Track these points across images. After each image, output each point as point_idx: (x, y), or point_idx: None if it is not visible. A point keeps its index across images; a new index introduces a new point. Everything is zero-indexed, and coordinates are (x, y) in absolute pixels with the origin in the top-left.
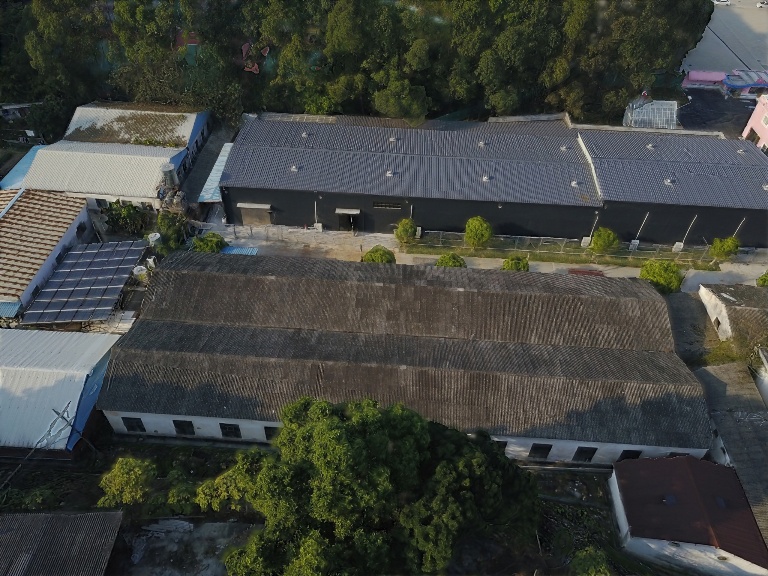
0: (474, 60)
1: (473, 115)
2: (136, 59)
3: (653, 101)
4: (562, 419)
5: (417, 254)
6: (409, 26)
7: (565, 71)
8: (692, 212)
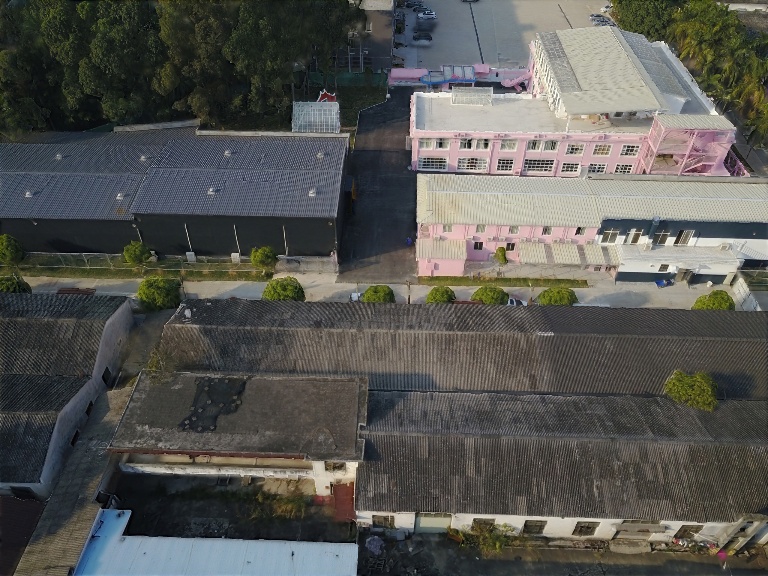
0: (75, 69)
1: None
2: None
3: (313, 102)
4: None
5: None
6: None
7: (169, 77)
8: (227, 222)
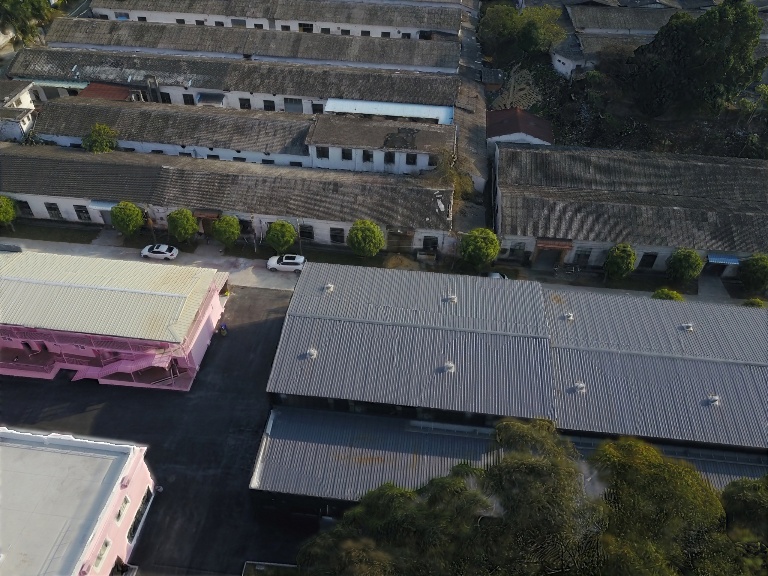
0: None
1: None
2: None
3: None
4: None
5: None
6: None
7: None
8: None
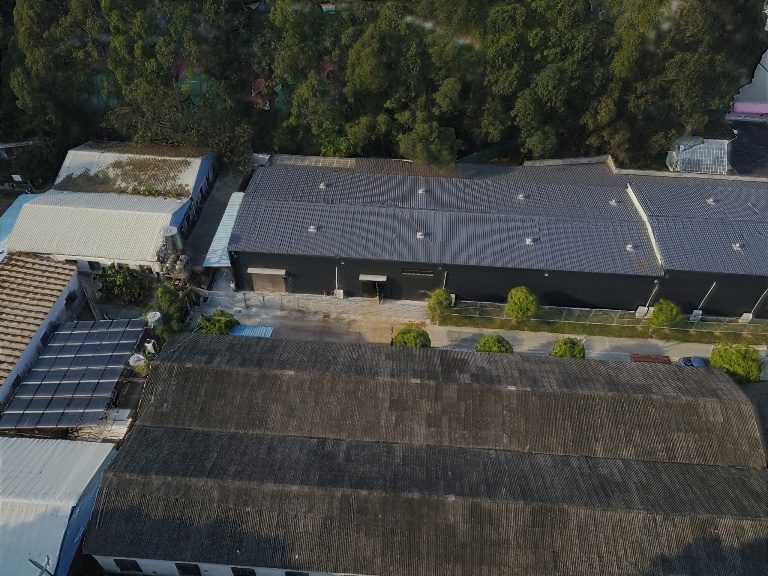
0: (510, 100)
1: (503, 153)
2: (134, 98)
3: None
4: (645, 567)
5: (451, 327)
6: (439, 64)
7: (611, 112)
8: (765, 282)
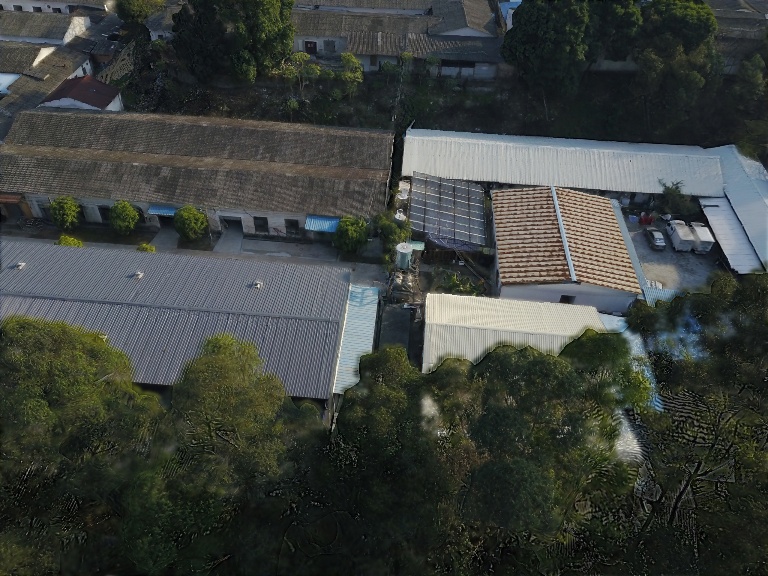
0: None
1: None
2: None
3: None
4: (120, 113)
5: None
6: None
7: None
8: None
